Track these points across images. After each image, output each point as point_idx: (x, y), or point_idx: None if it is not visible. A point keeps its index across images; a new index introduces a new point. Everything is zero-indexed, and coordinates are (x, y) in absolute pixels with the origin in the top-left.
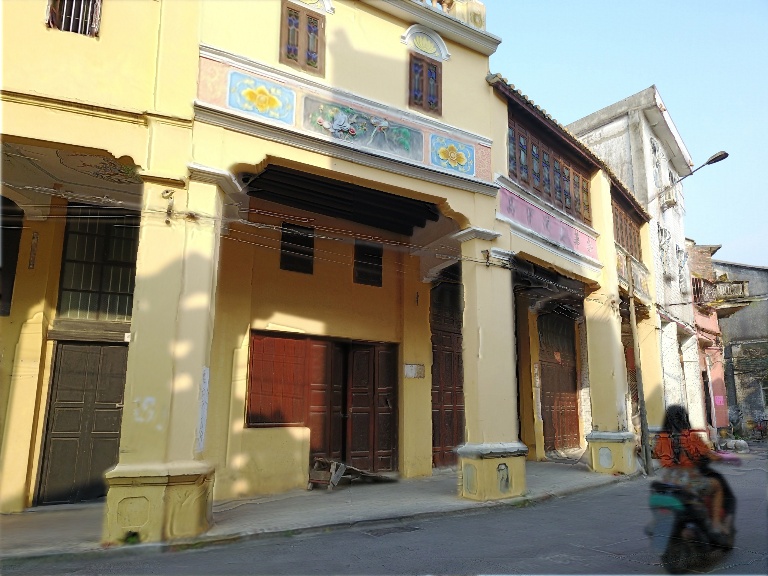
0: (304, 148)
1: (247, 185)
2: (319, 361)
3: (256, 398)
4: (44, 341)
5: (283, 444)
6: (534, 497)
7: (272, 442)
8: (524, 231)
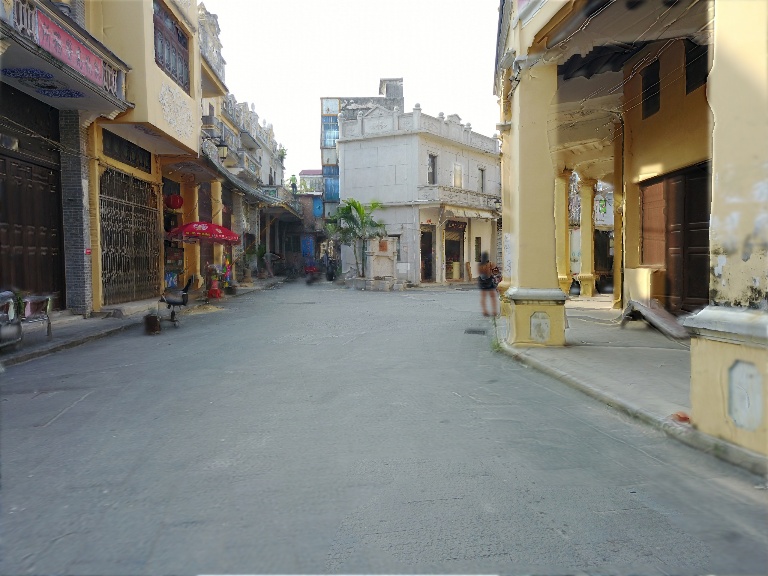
0: (502, 81)
1: (589, 78)
2: (674, 200)
3: (645, 243)
4: (618, 214)
5: (640, 283)
6: (507, 349)
7: (635, 281)
8: (535, 2)
